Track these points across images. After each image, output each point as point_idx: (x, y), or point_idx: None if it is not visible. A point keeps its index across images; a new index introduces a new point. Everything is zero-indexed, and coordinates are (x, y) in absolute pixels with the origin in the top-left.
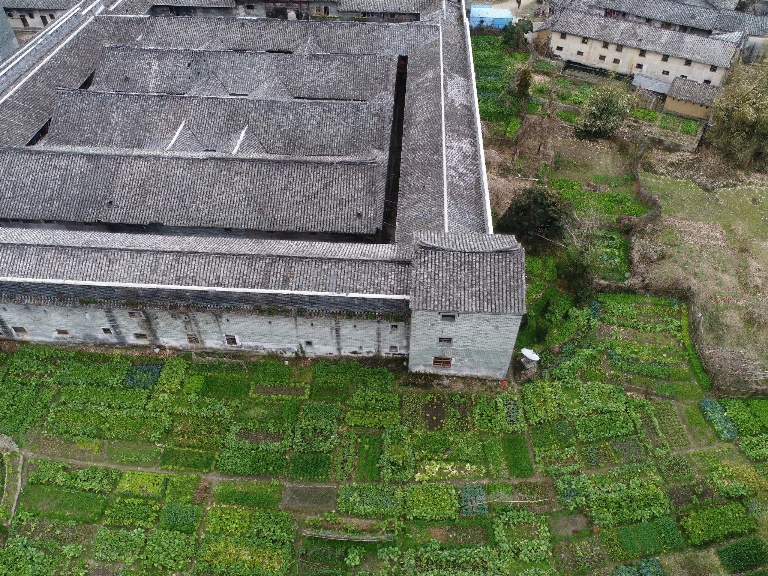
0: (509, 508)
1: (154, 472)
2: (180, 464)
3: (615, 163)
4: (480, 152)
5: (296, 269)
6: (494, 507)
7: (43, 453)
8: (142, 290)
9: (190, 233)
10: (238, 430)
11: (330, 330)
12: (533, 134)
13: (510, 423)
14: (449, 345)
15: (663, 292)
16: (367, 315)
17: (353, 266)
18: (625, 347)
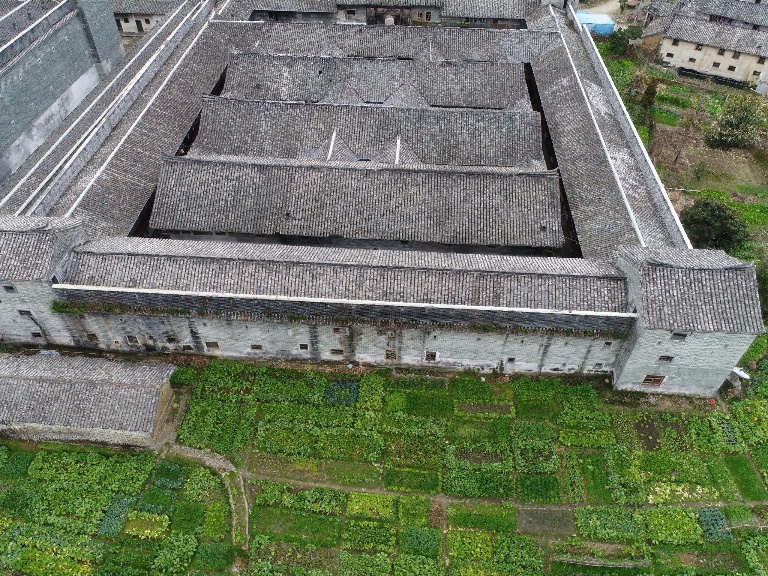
0: (755, 533)
1: (380, 493)
2: (406, 485)
3: (755, 173)
4: (648, 163)
5: (505, 285)
6: (739, 531)
7: (262, 473)
8: (356, 306)
9: (364, 245)
10: (454, 450)
11: (539, 347)
12: (665, 143)
13: (729, 443)
14: (668, 363)
15: None
16: (586, 333)
17: (564, 282)
18: None
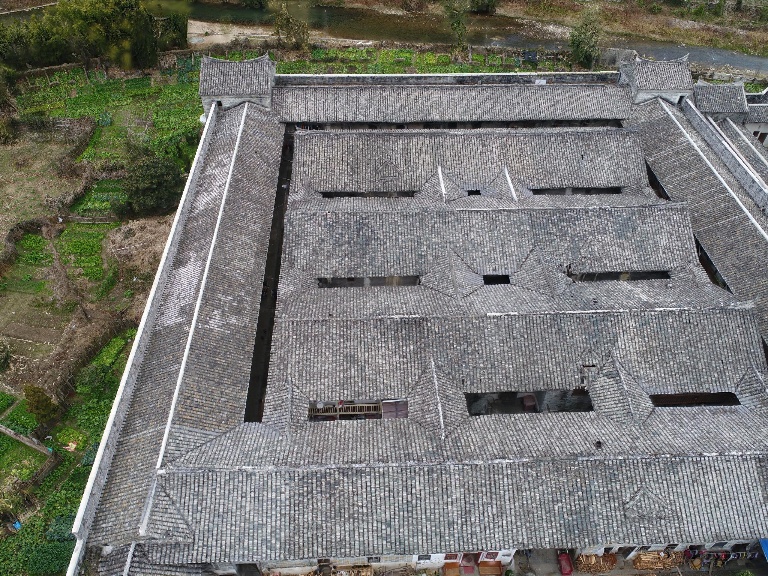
0: None
1: None
2: None
3: None
4: None
5: None
6: None
7: None
8: None
9: None
10: None
11: None
12: None
13: None
14: None
15: (78, 172)
16: None
17: None
18: None
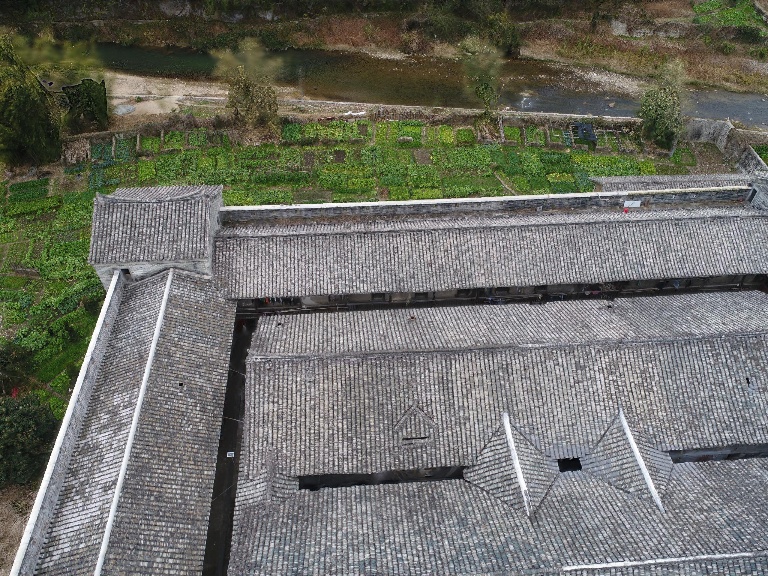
0: None
1: None
2: None
3: None
4: None
5: None
6: None
7: None
8: None
9: None
10: None
11: None
12: None
13: None
14: None
15: None
16: None
17: None
18: (5, 314)
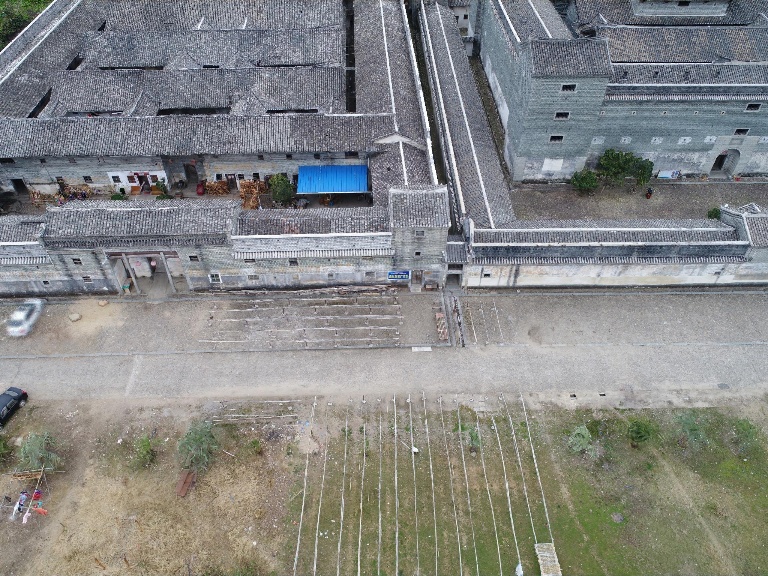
0: None
1: None
2: None
3: None
4: None
5: None
6: None
7: None
8: None
9: None
10: None
11: None
12: None
13: None
14: None
15: None
16: None
17: None
18: None
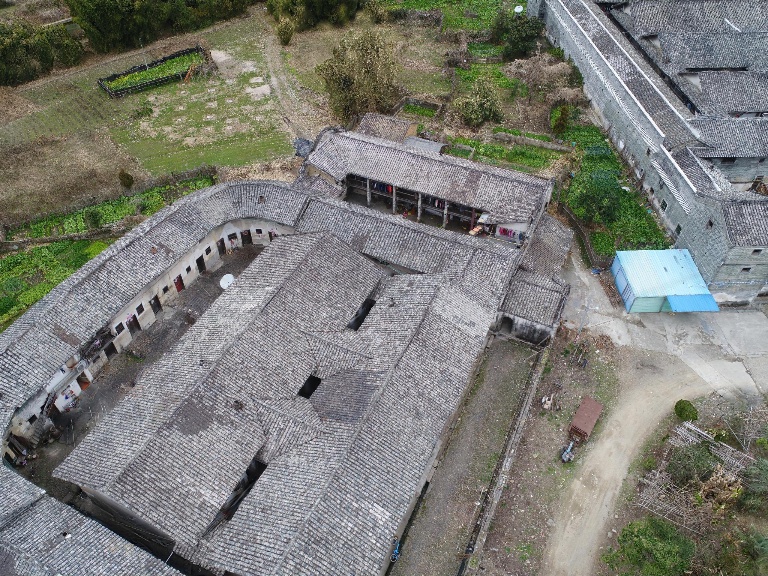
0: None
1: None
2: None
3: None
4: None
5: None
6: None
7: None
8: None
9: None
10: None
11: None
12: None
13: None
14: None
15: (452, 39)
16: None
17: None
18: None
